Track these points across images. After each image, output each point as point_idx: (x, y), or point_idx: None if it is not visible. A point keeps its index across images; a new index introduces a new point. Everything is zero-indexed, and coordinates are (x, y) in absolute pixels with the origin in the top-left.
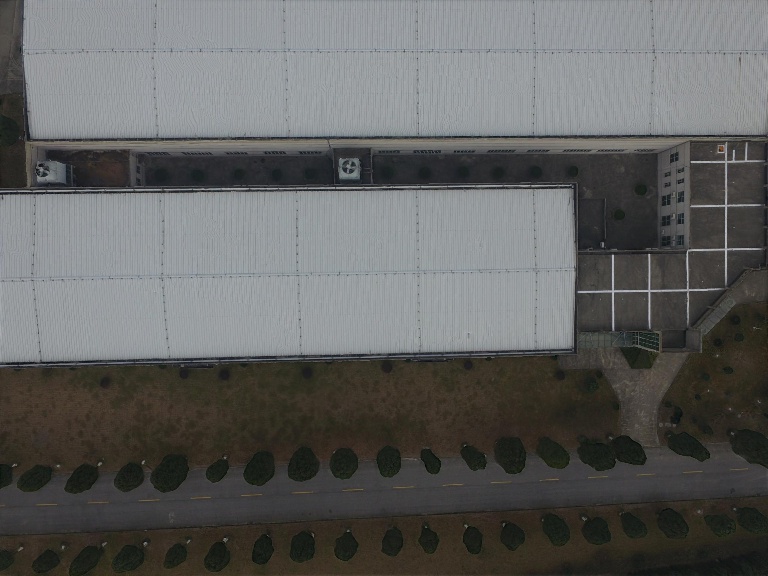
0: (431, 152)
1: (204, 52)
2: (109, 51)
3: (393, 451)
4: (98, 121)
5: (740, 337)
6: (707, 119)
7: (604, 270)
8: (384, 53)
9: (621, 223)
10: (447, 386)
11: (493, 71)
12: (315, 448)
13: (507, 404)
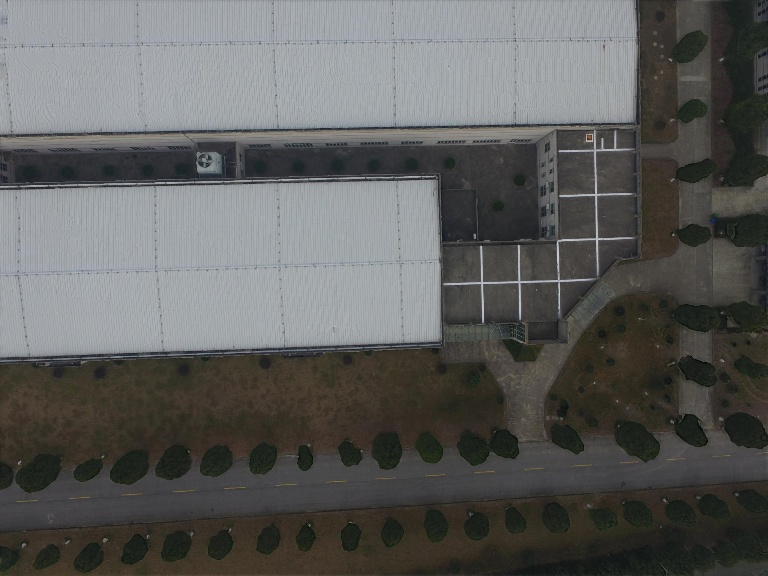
0: (302, 145)
1: (56, 47)
2: None
3: (266, 448)
4: None
5: (621, 328)
6: (569, 107)
7: (472, 262)
8: (239, 45)
9: (501, 215)
10: (327, 382)
11: (347, 62)
12: (194, 446)
13: (389, 399)
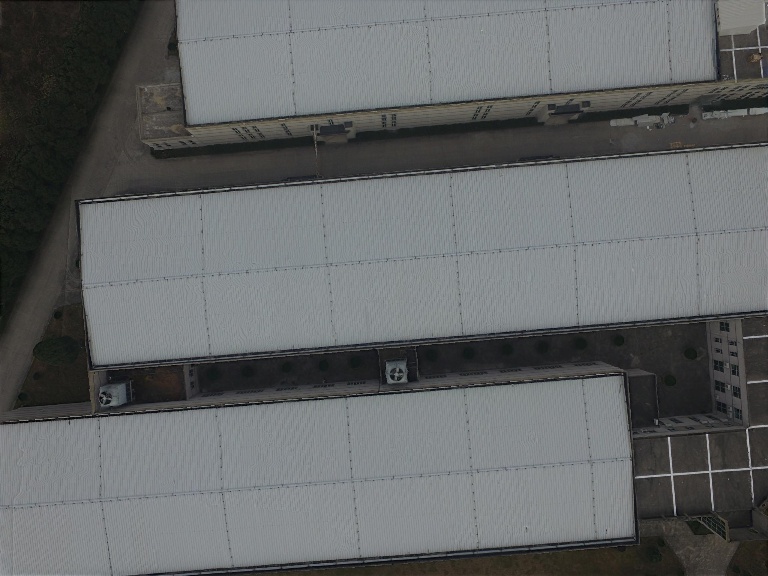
0: None
1: (250, 273)
2: (161, 279)
3: None
4: (154, 345)
5: None
6: (758, 301)
7: (661, 453)
8: (424, 259)
9: (672, 387)
10: (505, 562)
11: (534, 274)
12: None
13: None
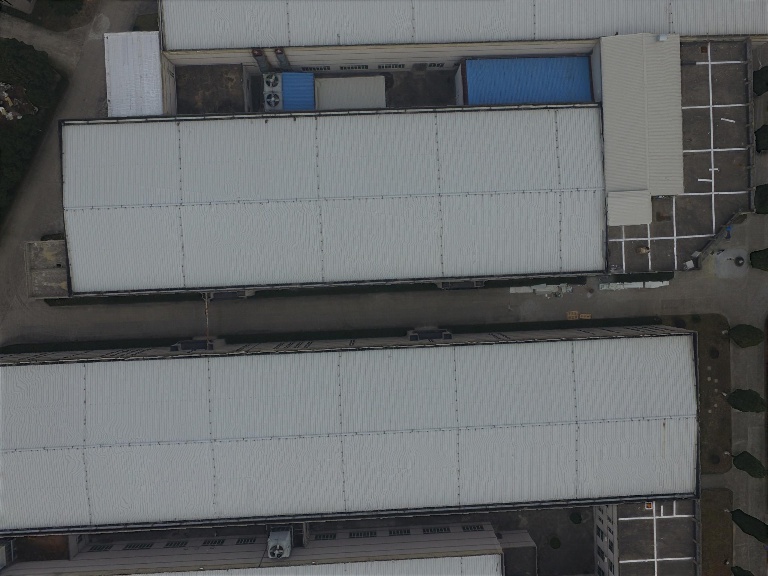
0: None
1: (133, 446)
2: (41, 449)
3: None
4: (33, 512)
5: None
6: (631, 491)
7: None
8: (308, 438)
9: None
10: None
11: (414, 462)
12: None
13: None
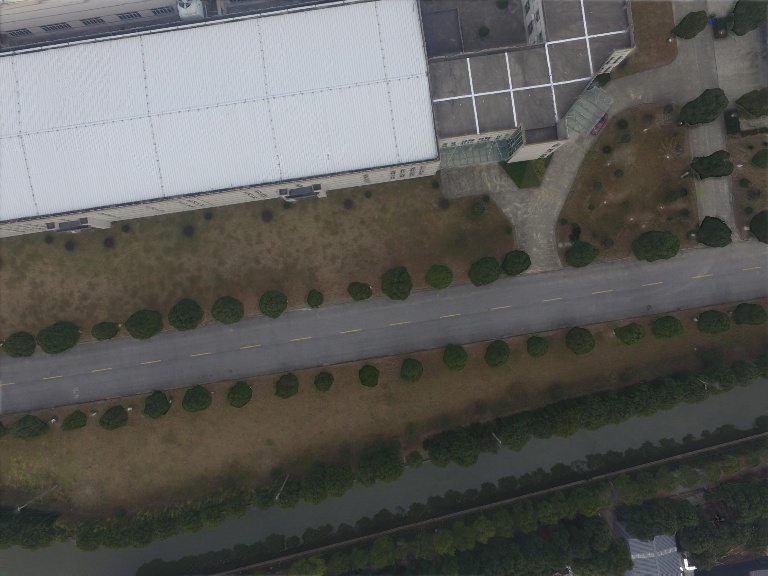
0: None
1: None
2: None
3: (275, 292)
4: None
5: (626, 137)
6: None
7: (461, 75)
8: None
9: (488, 41)
10: (331, 229)
11: None
12: (207, 307)
13: (395, 241)
